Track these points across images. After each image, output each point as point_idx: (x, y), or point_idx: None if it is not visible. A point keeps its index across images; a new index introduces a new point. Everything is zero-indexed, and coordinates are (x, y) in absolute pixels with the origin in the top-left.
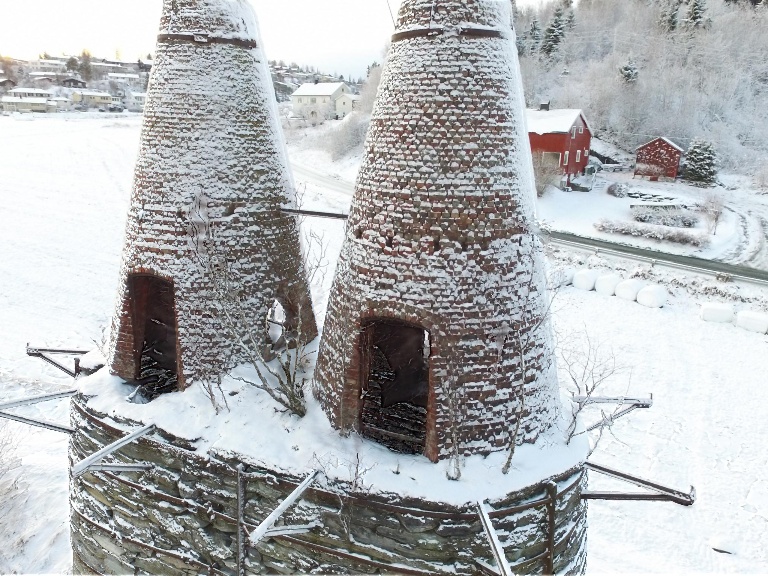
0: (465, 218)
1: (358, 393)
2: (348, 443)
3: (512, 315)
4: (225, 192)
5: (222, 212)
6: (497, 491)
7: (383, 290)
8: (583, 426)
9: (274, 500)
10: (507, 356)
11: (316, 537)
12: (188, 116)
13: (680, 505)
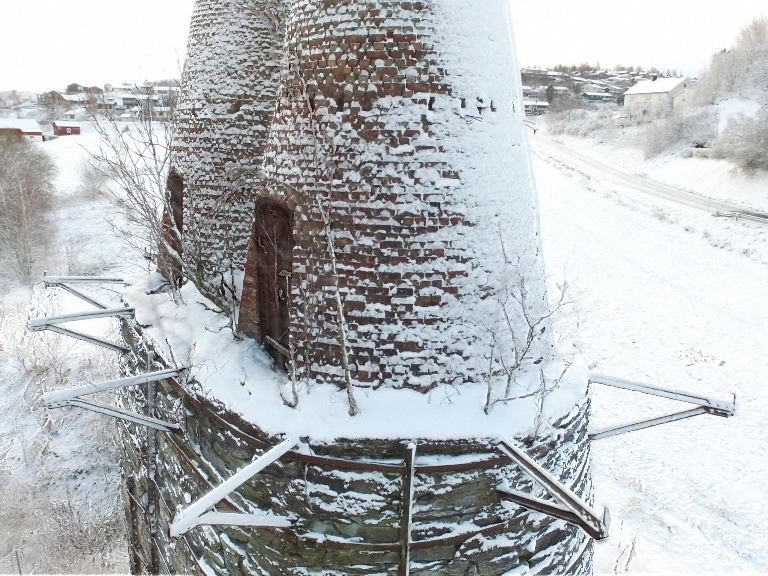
0: (343, 66)
1: (256, 294)
2: (233, 347)
3: (400, 203)
4: (232, 88)
5: (228, 109)
6: (325, 431)
7: (268, 166)
8: (552, 402)
9: (167, 395)
10: (386, 259)
11: None
12: (209, 12)
13: (588, 535)
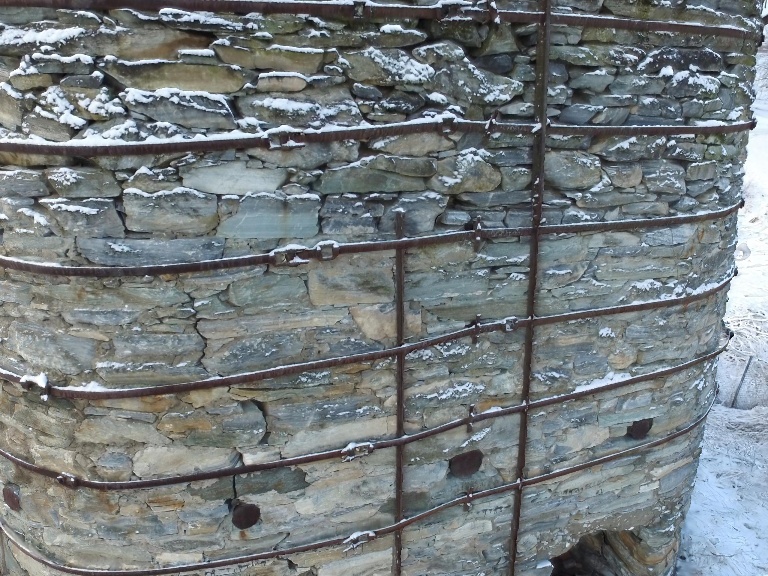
0: None
1: None
2: None
3: None
4: None
5: None
6: None
7: None
8: None
9: None
10: None
11: (644, 12)
12: None
13: None
